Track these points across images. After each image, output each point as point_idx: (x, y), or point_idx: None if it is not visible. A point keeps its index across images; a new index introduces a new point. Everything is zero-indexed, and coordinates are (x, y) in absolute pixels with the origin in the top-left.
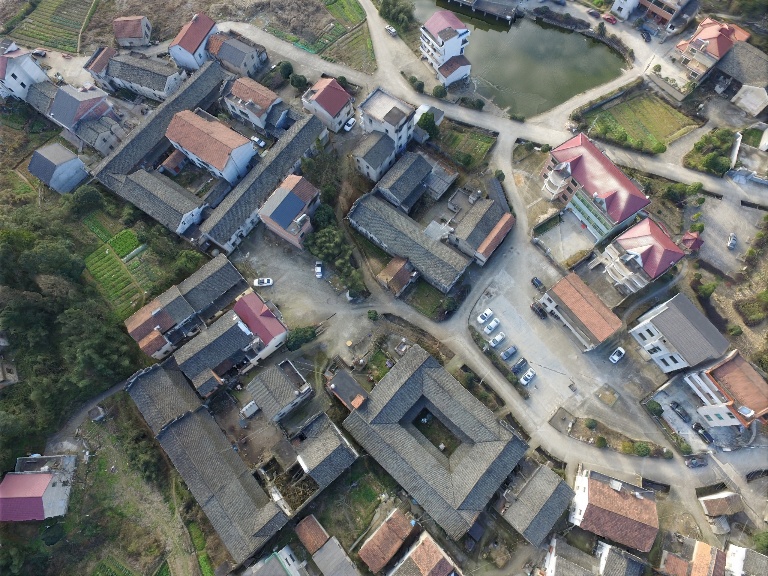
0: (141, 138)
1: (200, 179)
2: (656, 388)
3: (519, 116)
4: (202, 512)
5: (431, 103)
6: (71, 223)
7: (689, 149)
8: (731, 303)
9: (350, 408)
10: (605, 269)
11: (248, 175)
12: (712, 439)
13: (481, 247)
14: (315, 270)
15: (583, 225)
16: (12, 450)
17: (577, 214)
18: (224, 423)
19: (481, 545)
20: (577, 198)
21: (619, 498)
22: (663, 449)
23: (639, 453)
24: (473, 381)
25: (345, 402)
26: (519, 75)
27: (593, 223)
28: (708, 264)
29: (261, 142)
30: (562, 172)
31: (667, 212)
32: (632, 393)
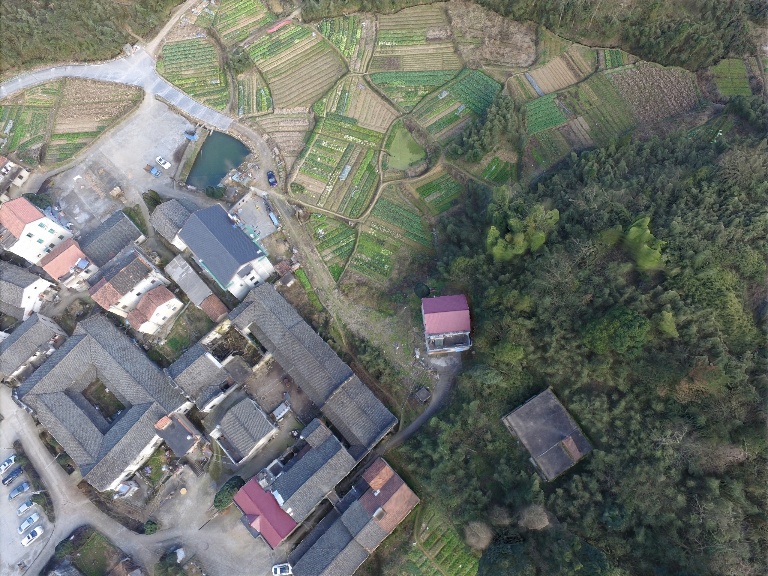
0: None
1: None
2: None
3: None
4: (313, 319)
5: None
6: None
7: None
8: None
9: (175, 417)
10: None
11: None
12: None
13: None
14: None
15: None
16: None
17: None
18: None
19: (91, 314)
20: None
21: None
22: None
23: None
24: None
25: (179, 422)
26: None
27: None
28: None
29: None
30: None
31: None
32: None
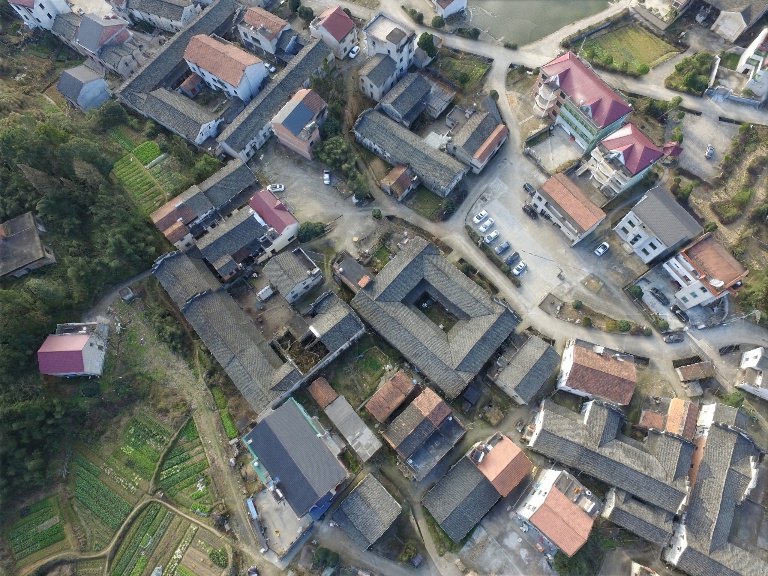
0: (161, 61)
1: (215, 101)
2: (638, 277)
3: (512, 43)
4: (223, 378)
5: (430, 33)
6: (98, 135)
7: (671, 72)
8: (708, 205)
9: (357, 288)
10: (591, 174)
11: (260, 93)
12: (688, 318)
13: (477, 153)
14: (323, 177)
15: (571, 138)
16: (52, 319)
17: (566, 127)
18: (242, 306)
19: (477, 408)
20: (565, 109)
21: (601, 360)
22: (643, 327)
23: (621, 328)
24: (469, 272)
25: (352, 283)
26: (512, 5)
27: (580, 132)
28: (687, 171)
29: (272, 68)
30: (551, 85)
31: (650, 127)
32: (615, 281)
